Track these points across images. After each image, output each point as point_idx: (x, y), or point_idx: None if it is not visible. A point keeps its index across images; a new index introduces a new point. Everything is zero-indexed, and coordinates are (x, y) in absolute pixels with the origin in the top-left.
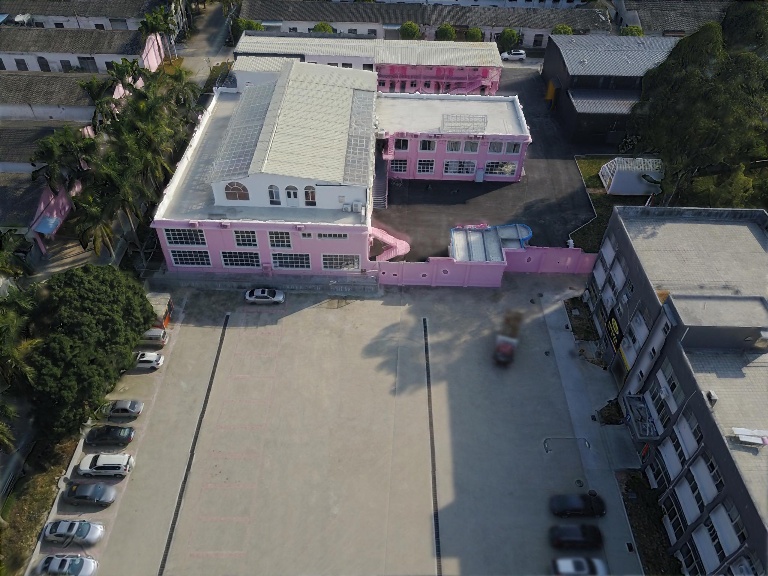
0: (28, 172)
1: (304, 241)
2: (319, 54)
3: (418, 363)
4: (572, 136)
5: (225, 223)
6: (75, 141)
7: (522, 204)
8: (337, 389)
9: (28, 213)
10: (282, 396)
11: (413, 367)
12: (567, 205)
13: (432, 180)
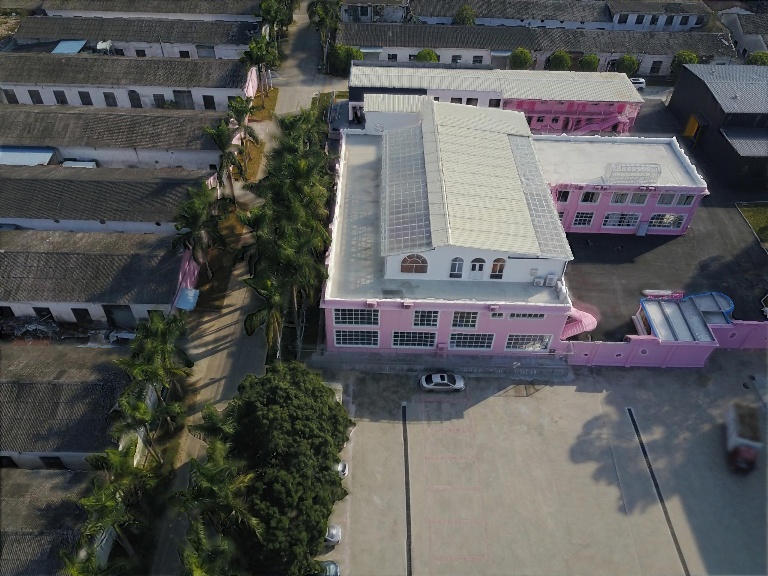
0: (150, 231)
1: (492, 321)
2: (443, 88)
3: (639, 468)
4: (729, 180)
5: (408, 303)
6: (215, 201)
7: (696, 263)
8: (558, 505)
9: (168, 287)
10: (496, 515)
11: (635, 473)
12: (746, 264)
13: (588, 233)
